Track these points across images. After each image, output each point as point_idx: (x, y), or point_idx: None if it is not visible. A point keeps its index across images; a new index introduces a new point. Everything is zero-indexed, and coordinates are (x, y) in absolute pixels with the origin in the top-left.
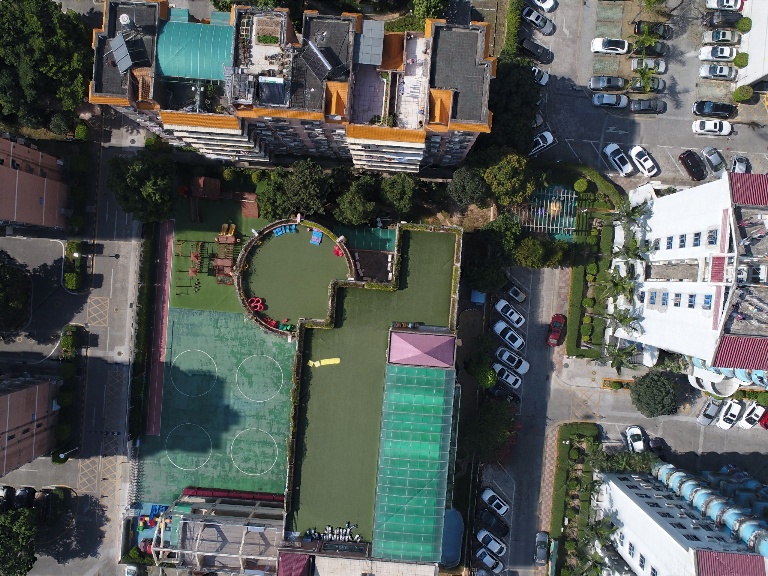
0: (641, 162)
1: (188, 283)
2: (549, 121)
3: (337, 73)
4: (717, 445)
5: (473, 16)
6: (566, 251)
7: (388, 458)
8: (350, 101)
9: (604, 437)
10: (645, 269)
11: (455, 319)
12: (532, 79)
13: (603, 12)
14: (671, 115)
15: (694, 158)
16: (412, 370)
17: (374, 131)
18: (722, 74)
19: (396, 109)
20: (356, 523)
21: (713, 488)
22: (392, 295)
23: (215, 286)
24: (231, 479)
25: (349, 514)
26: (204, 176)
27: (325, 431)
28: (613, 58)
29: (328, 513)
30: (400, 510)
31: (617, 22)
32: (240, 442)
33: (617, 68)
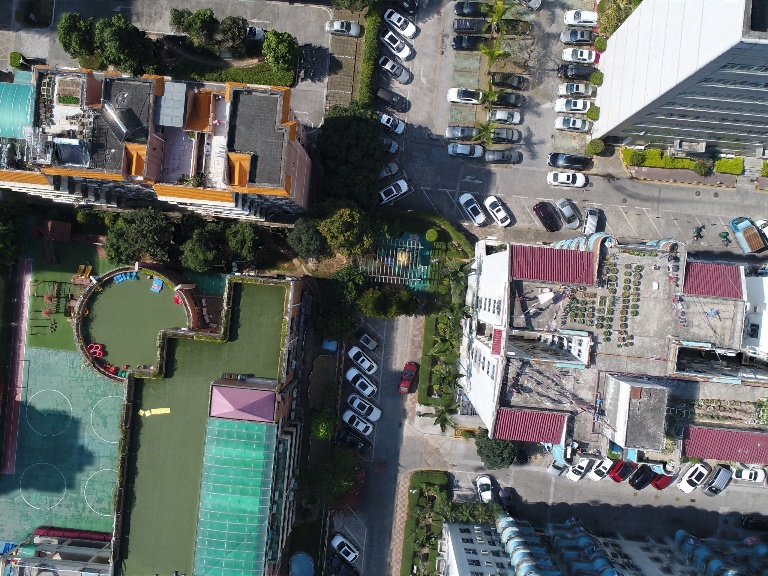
0: (494, 212)
1: (45, 323)
2: (405, 169)
3: (138, 134)
4: (568, 496)
5: (332, 63)
6: (406, 303)
7: (208, 511)
8: (155, 161)
9: (455, 485)
10: (477, 325)
11: (282, 372)
12: (376, 131)
13: (460, 62)
14: (527, 166)
15: (546, 210)
16: (232, 424)
17: (181, 190)
18: (575, 127)
19: (205, 168)
20: (184, 573)
21: (540, 545)
22: (223, 346)
23: (71, 327)
24: (84, 519)
25: (177, 563)
26: (57, 219)
27: (154, 480)
28: (470, 108)
29: (156, 562)
30: (219, 563)
31: (474, 72)
32: (94, 482)
33: (473, 118)
